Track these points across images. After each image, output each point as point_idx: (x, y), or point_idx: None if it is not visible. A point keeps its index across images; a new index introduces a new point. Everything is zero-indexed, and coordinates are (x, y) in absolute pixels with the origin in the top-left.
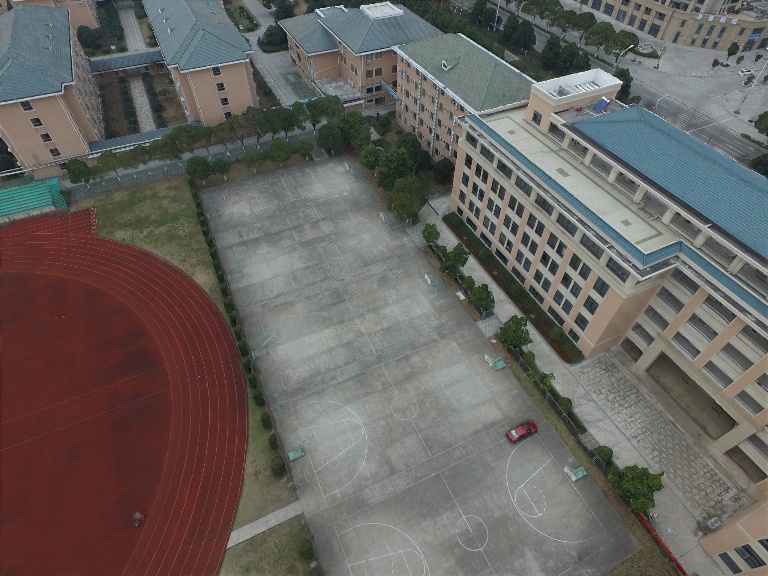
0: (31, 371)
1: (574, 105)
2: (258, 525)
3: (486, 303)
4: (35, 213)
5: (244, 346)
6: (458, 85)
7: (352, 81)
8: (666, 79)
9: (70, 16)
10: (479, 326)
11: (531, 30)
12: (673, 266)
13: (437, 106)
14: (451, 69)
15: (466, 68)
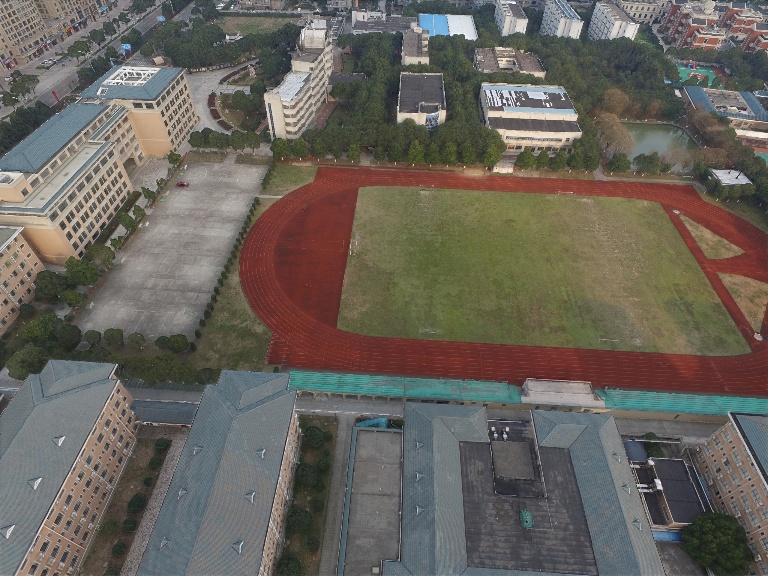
0: (326, 265)
1: None
2: (273, 197)
3: None
4: None
5: None
6: None
7: None
8: None
9: None
10: (151, 213)
11: None
12: None
13: None
14: None
15: None
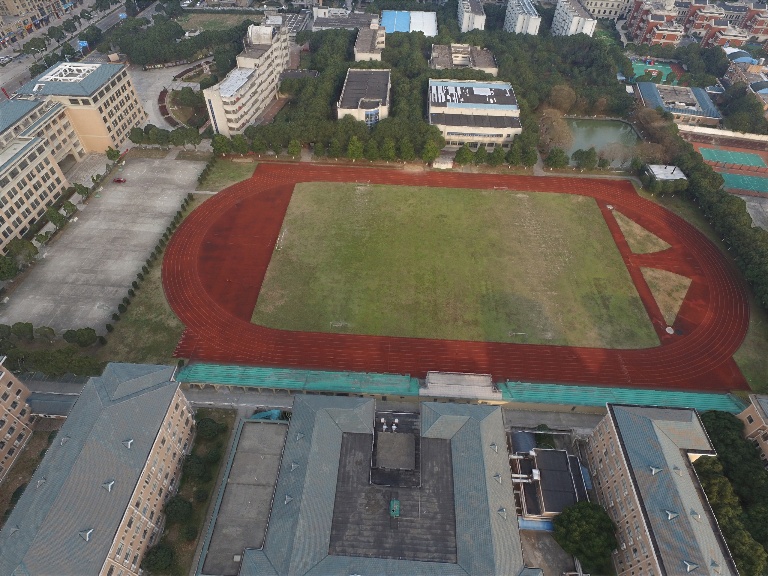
0: (250, 260)
1: None
2: None
3: None
4: None
5: None
6: None
7: None
8: None
9: None
10: (83, 209)
11: None
12: None
13: None
14: None
15: None
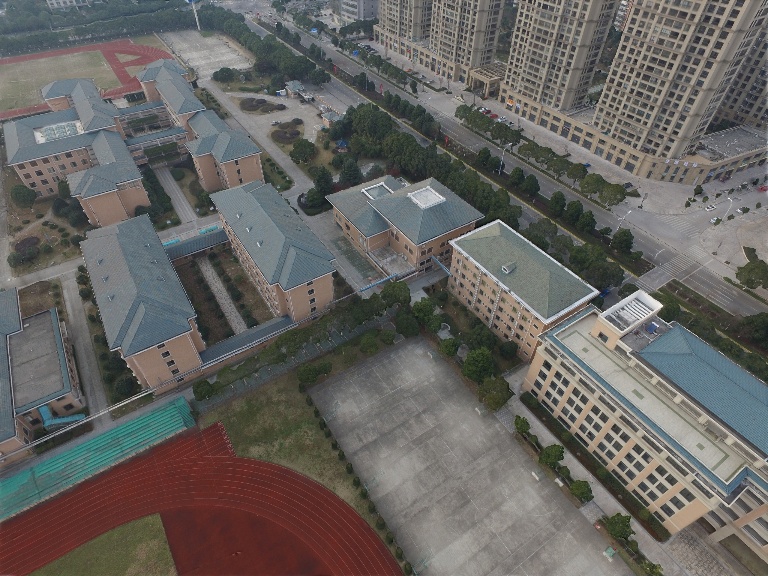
0: None
1: (632, 329)
2: None
3: (587, 495)
4: (170, 436)
5: (411, 568)
6: (521, 290)
7: (405, 256)
8: (651, 220)
9: (128, 199)
10: (583, 513)
11: (536, 182)
12: None
13: (499, 298)
14: (511, 273)
15: (524, 274)
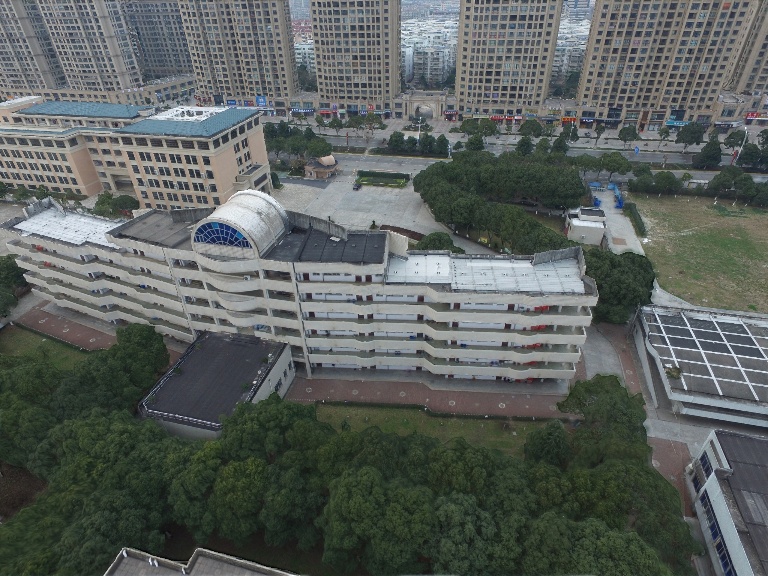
0: None
1: (20, 109)
2: None
3: (26, 196)
4: None
5: None
6: None
7: None
8: None
9: None
10: None
11: None
12: (77, 134)
13: None
14: None
15: None
